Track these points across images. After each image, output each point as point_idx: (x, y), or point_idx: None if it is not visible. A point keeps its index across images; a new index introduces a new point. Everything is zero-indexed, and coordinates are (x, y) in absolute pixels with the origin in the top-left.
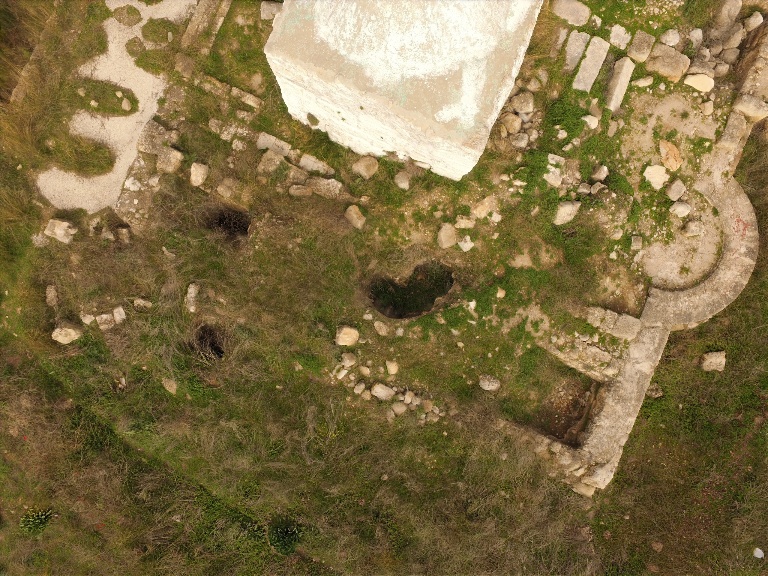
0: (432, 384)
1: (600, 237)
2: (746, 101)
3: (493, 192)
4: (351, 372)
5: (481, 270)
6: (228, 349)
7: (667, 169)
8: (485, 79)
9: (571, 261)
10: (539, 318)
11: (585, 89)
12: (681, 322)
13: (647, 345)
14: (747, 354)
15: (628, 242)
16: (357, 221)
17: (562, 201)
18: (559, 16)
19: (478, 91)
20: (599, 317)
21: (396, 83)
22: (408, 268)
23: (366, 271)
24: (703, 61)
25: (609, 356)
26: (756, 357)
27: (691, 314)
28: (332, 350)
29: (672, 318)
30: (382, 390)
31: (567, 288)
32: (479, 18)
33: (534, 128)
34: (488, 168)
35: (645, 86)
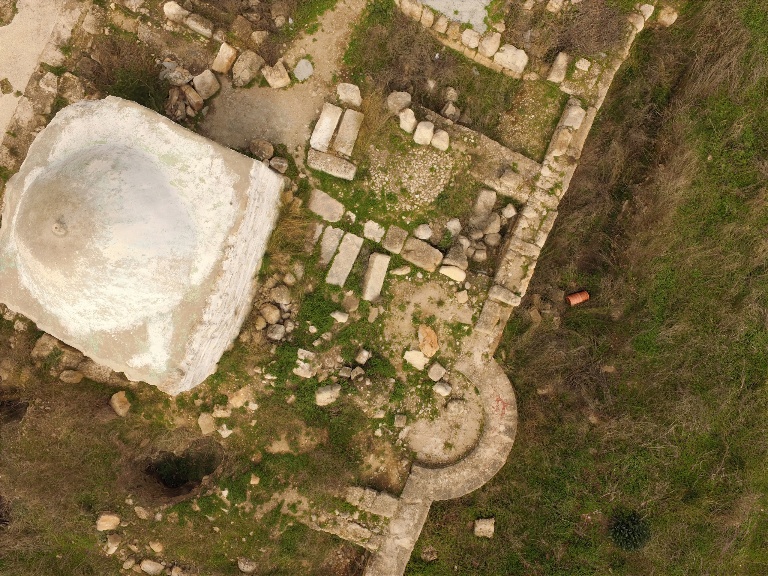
0: (196, 561)
1: (364, 416)
2: (495, 293)
3: (248, 383)
4: (121, 548)
5: (239, 455)
6: (12, 519)
7: (425, 354)
8: (172, 329)
9: (334, 441)
10: (297, 500)
11: (338, 283)
12: (441, 498)
13: (407, 521)
14: (516, 521)
15: (391, 421)
16: (119, 410)
17: (321, 386)
18: (314, 212)
19: (167, 340)
20: (358, 497)
21: (87, 334)
22: (184, 442)
23: (138, 450)
24: (458, 251)
25: (369, 533)
26: (524, 524)
27: (451, 491)
28: (95, 533)
29: (432, 495)
30: (149, 566)
31: (325, 470)
32: (151, 285)
33: (291, 319)
34: (242, 362)
35: (404, 274)
